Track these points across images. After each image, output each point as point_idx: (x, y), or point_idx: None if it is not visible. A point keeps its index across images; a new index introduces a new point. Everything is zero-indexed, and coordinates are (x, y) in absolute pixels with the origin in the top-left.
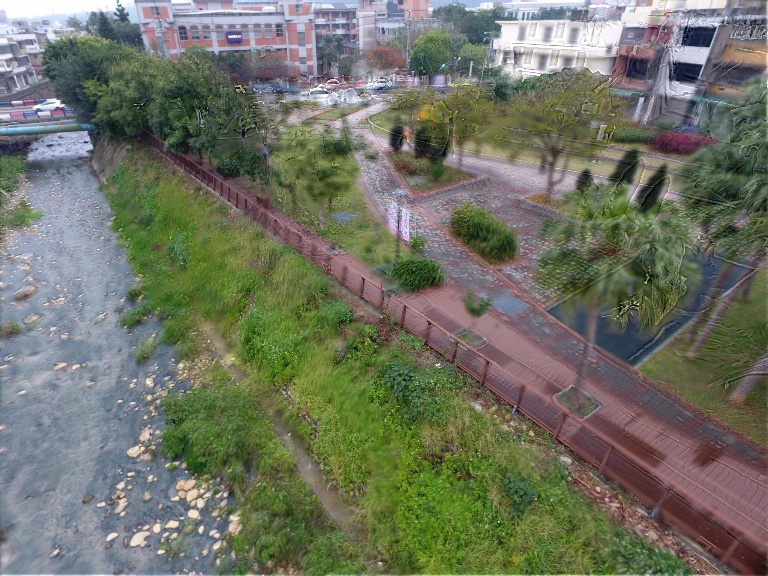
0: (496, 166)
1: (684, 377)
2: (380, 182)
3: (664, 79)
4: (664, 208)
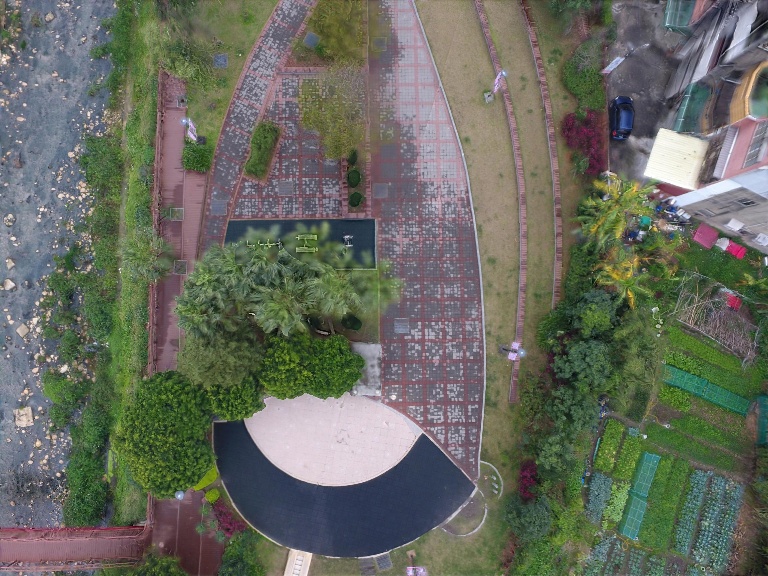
0: (401, 47)
1: None
2: (282, 20)
3: (710, 22)
4: (428, 189)
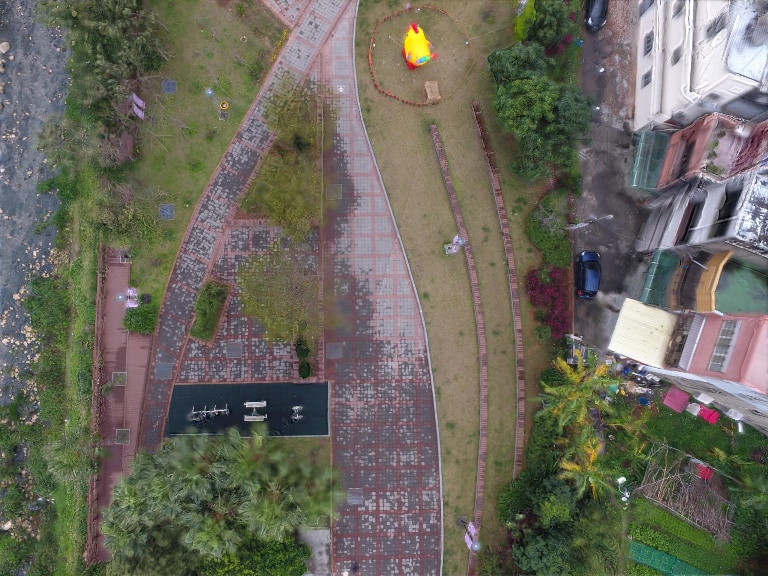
0: (357, 195)
1: (182, 455)
2: (232, 167)
3: (679, 189)
4: (385, 349)
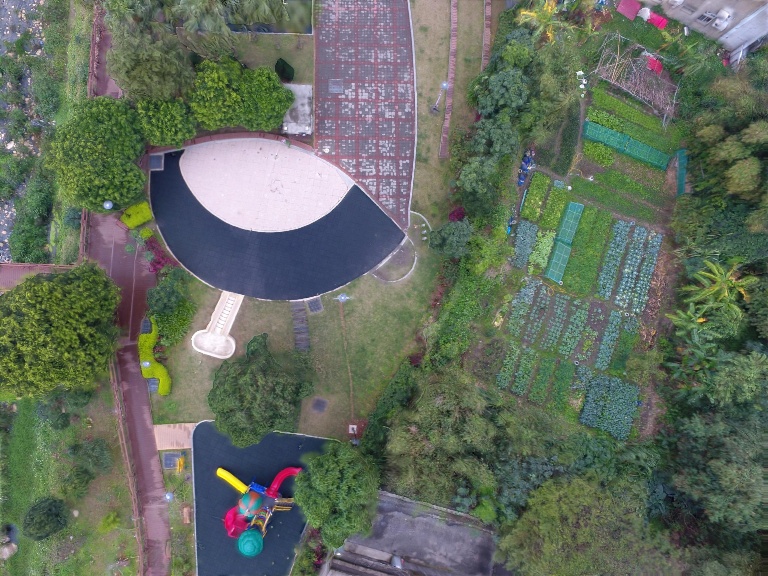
0: None
1: None
2: None
3: None
4: None
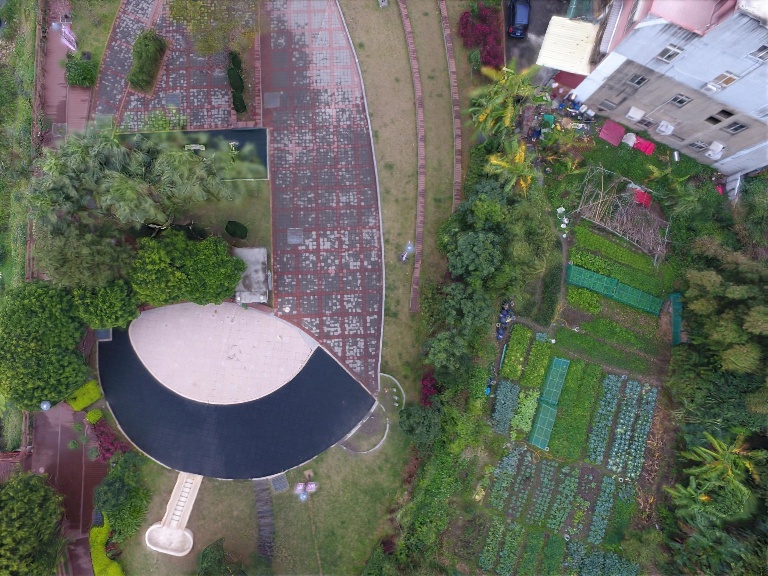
0: None
1: None
2: None
3: None
4: (322, 97)
